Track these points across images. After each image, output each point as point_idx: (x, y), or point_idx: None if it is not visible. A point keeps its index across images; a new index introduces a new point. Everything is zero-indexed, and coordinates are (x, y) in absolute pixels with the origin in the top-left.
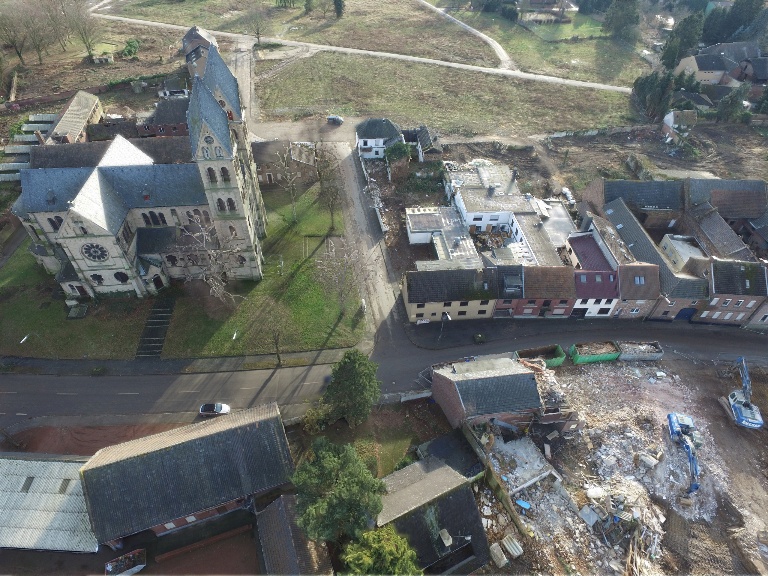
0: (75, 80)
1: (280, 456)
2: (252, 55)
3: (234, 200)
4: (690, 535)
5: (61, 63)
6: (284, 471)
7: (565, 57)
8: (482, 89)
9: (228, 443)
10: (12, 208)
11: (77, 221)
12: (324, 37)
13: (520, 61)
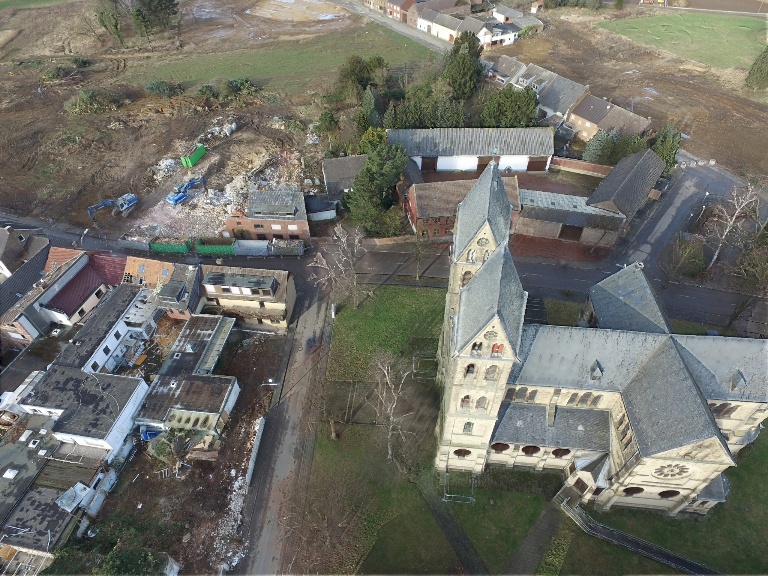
0: None
1: None
2: None
3: None
4: (220, 184)
5: None
6: None
7: None
8: None
9: None
10: None
11: None
12: None
13: None
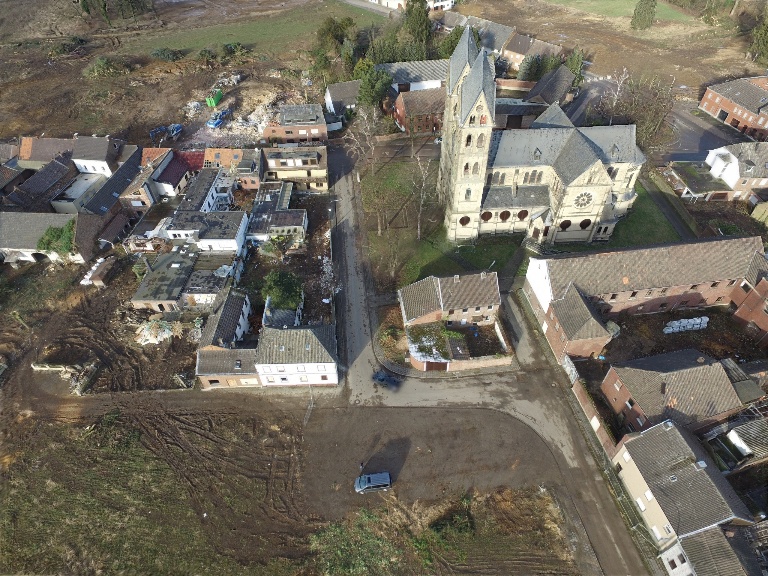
0: None
1: None
2: None
3: None
4: None
5: None
6: None
7: None
8: None
9: None
10: None
11: None
12: None
13: None
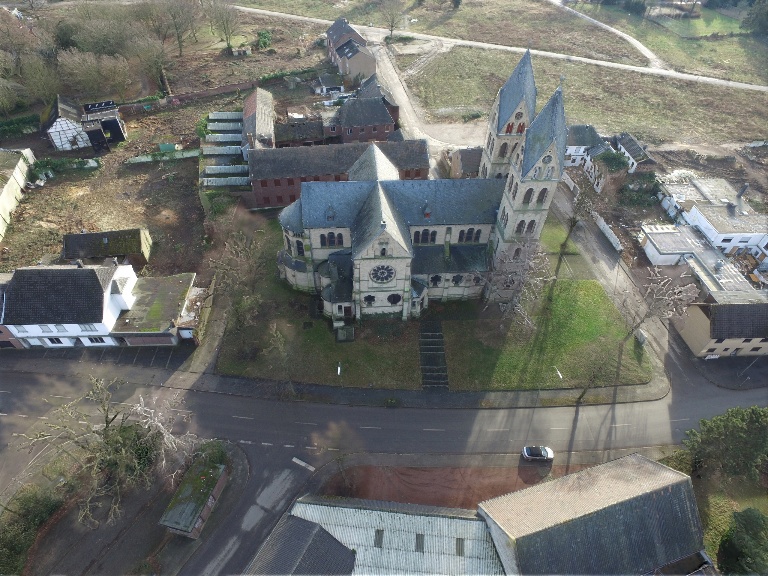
0: (222, 73)
1: (690, 523)
2: (387, 49)
3: (536, 222)
4: None
5: (199, 55)
6: (694, 540)
7: (714, 56)
8: (645, 90)
9: (644, 509)
10: (281, 222)
11: (382, 242)
12: (451, 30)
13: (669, 60)
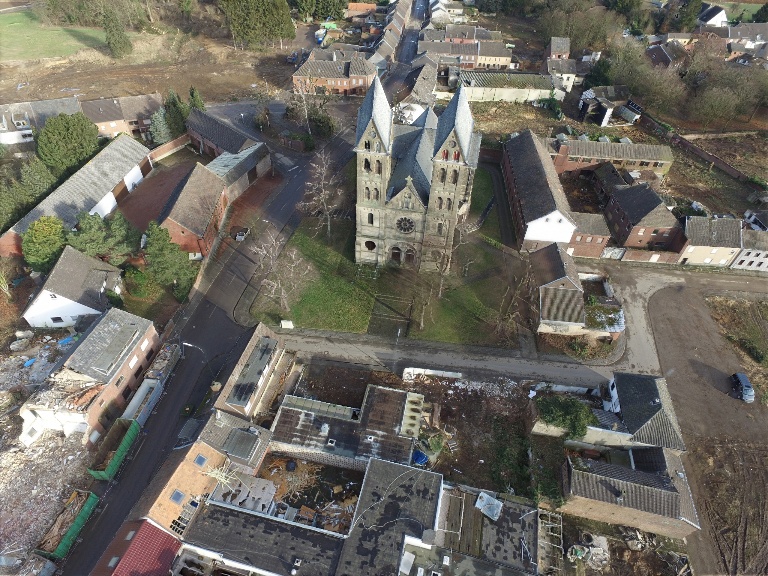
0: (763, 163)
1: None
2: None
3: None
4: None
5: None
6: None
7: None
8: None
9: None
10: None
11: None
12: None
13: None
